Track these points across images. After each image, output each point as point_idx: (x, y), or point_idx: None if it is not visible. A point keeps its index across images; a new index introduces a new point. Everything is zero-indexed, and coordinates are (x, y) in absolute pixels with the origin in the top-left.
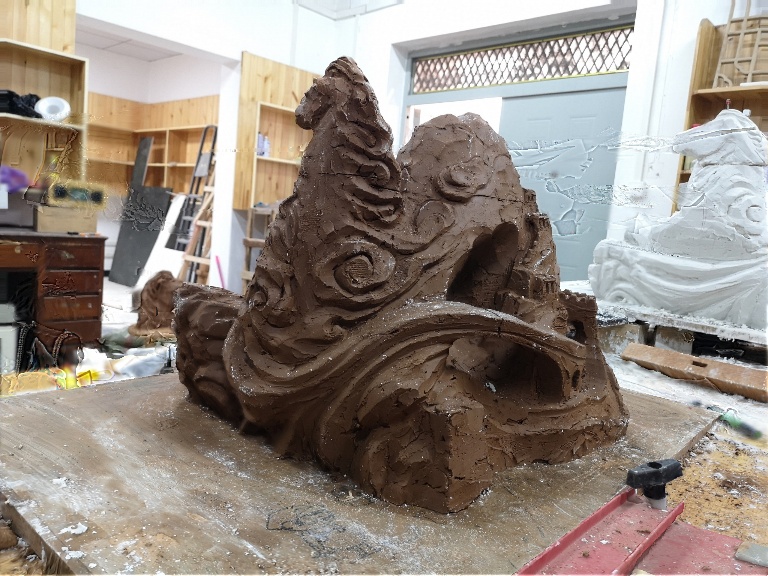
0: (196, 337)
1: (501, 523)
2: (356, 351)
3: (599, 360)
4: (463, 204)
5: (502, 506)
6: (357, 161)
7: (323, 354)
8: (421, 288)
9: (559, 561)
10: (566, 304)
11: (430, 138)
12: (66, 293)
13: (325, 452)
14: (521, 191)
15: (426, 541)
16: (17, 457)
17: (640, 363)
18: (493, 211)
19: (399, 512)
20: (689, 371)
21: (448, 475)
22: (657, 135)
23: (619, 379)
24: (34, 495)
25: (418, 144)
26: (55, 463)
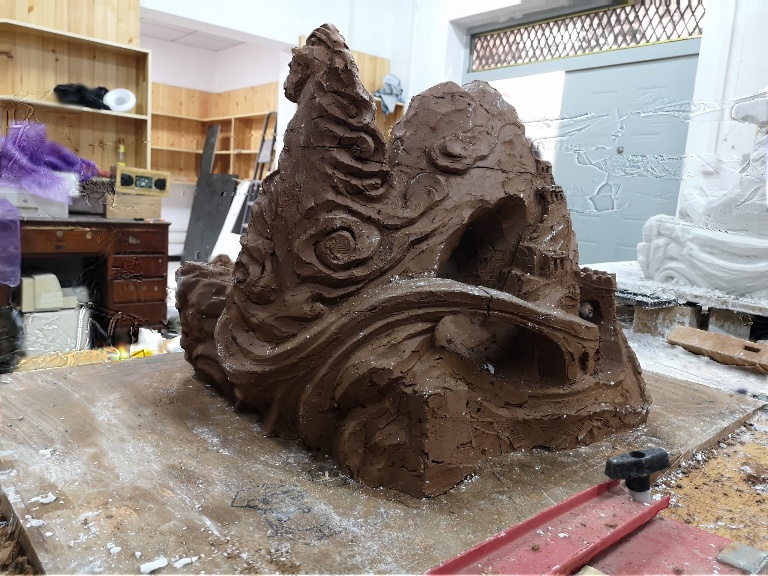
0: (194, 315)
1: (478, 510)
2: (333, 329)
3: (616, 342)
4: (459, 176)
5: (485, 493)
6: (337, 132)
7: (303, 332)
8: (408, 264)
9: (502, 553)
10: (581, 282)
11: (426, 108)
12: (133, 276)
13: (304, 431)
14: (532, 162)
15: (391, 525)
16: (14, 428)
17: (687, 347)
18: (495, 183)
19: (372, 495)
20: (740, 356)
21: (424, 458)
22: (699, 99)
23: (660, 364)
24: (18, 464)
25: (413, 114)
26: (47, 435)
